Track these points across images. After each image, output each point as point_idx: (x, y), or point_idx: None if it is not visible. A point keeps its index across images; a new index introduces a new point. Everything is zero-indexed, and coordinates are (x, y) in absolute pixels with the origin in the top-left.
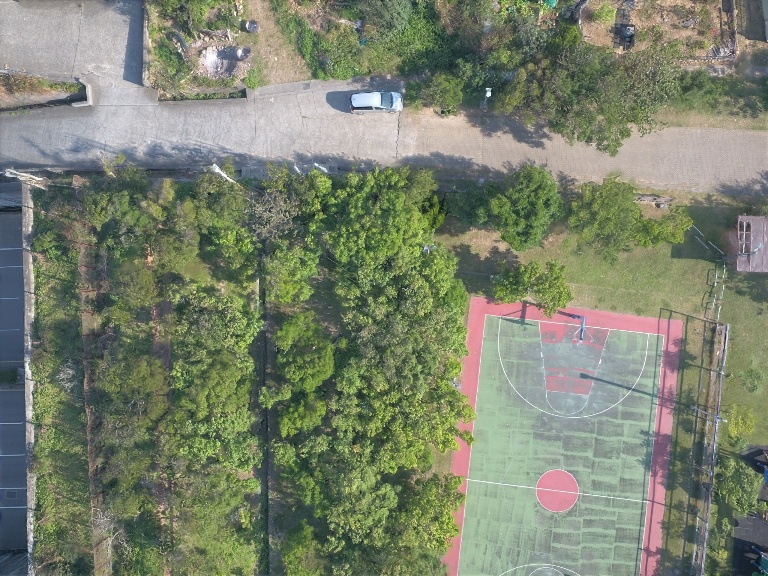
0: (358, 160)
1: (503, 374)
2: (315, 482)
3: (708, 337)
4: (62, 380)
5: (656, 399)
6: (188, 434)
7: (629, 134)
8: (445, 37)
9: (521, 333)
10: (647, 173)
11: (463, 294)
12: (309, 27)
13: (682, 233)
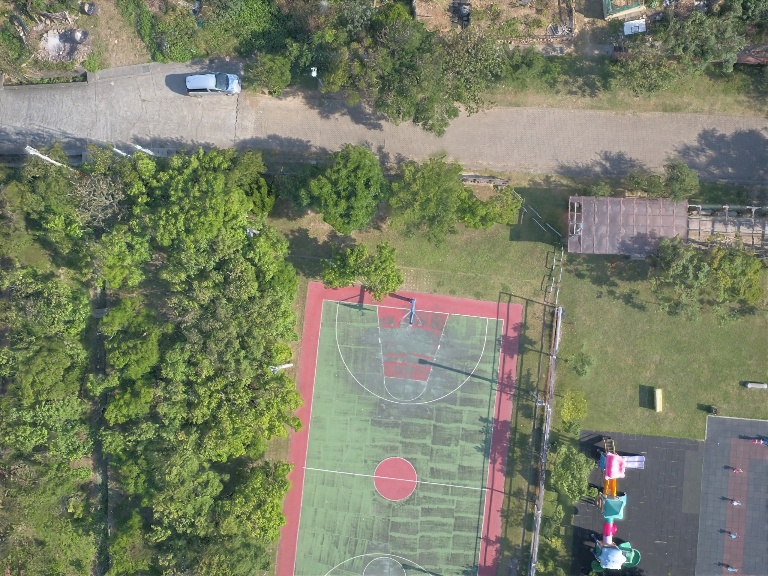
0: (196, 143)
1: (341, 360)
2: (141, 470)
3: (548, 321)
4: None
5: (495, 385)
6: (15, 422)
7: (456, 114)
8: (280, 17)
9: (359, 318)
10: (485, 154)
11: (292, 278)
12: (148, 9)
13: (511, 214)
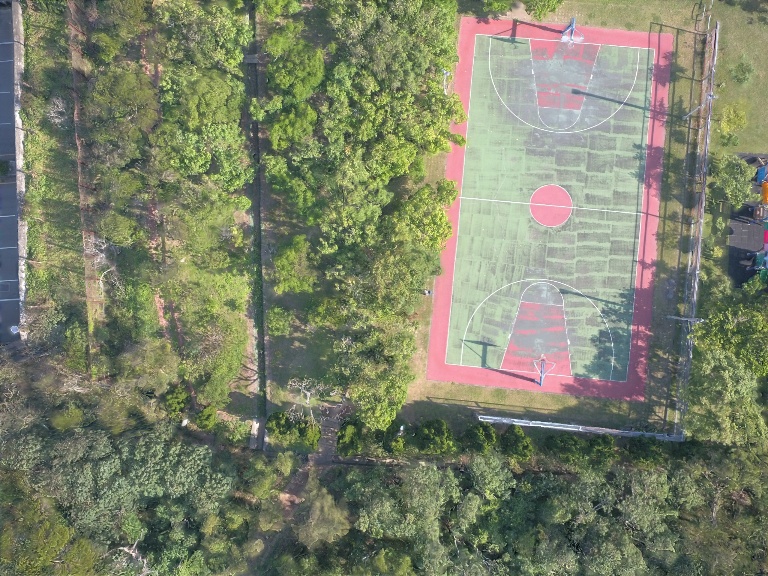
0: None
1: (494, 92)
2: (307, 188)
3: (699, 49)
4: (52, 118)
5: (648, 112)
6: (179, 148)
7: None
8: None
9: (512, 51)
10: None
11: None
12: None
13: None
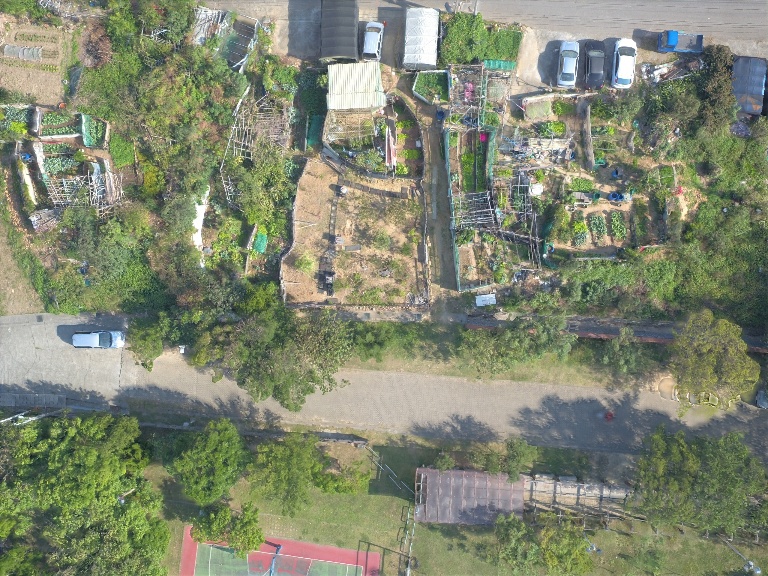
0: (84, 392)
1: None
2: None
3: (403, 570)
4: None
5: None
6: None
7: (312, 391)
8: (159, 281)
9: (230, 561)
10: (347, 414)
11: (163, 534)
12: (40, 264)
13: None
